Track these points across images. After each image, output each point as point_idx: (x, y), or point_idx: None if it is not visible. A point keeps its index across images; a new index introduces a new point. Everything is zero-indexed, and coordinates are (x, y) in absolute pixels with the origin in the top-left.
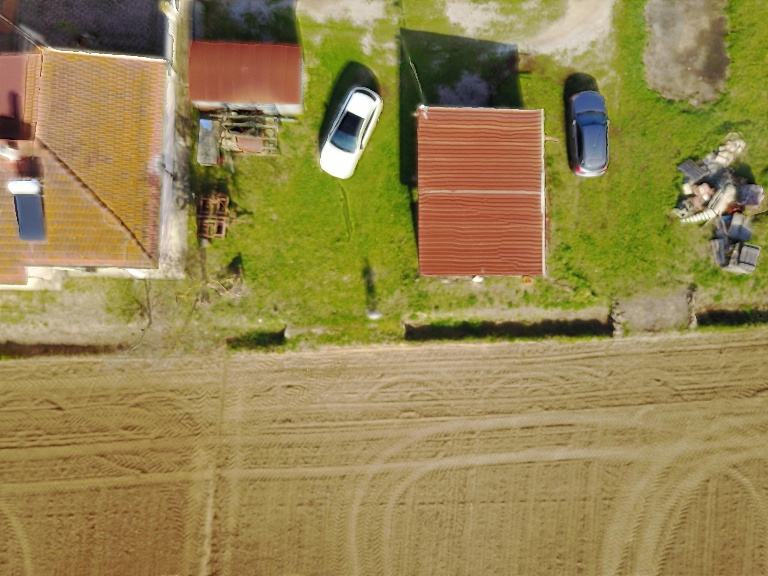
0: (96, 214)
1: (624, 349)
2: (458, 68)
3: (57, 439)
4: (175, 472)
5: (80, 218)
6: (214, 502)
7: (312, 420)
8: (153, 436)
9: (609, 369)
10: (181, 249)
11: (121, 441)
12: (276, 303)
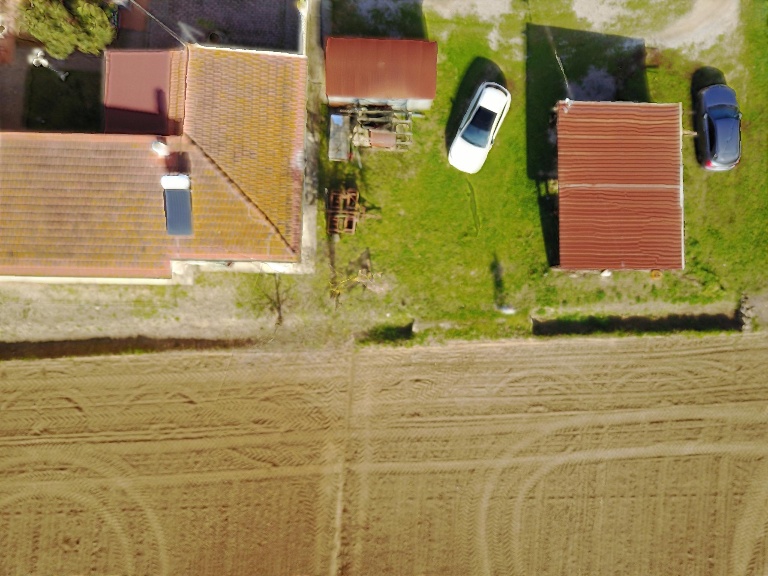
0: (241, 209)
1: (753, 344)
2: (584, 62)
3: (190, 432)
4: (306, 465)
5: (225, 213)
6: (343, 495)
7: (440, 414)
8: (283, 429)
9: (738, 364)
10: (310, 244)
11: (252, 434)
12: (404, 297)
